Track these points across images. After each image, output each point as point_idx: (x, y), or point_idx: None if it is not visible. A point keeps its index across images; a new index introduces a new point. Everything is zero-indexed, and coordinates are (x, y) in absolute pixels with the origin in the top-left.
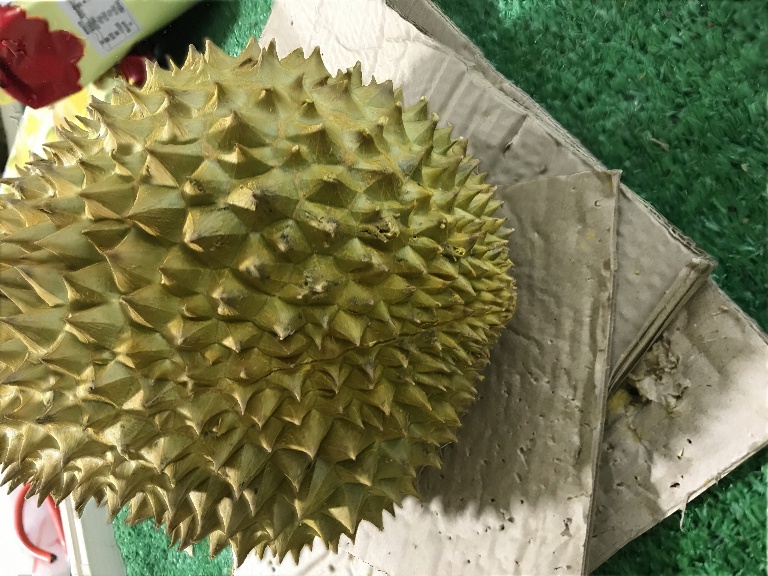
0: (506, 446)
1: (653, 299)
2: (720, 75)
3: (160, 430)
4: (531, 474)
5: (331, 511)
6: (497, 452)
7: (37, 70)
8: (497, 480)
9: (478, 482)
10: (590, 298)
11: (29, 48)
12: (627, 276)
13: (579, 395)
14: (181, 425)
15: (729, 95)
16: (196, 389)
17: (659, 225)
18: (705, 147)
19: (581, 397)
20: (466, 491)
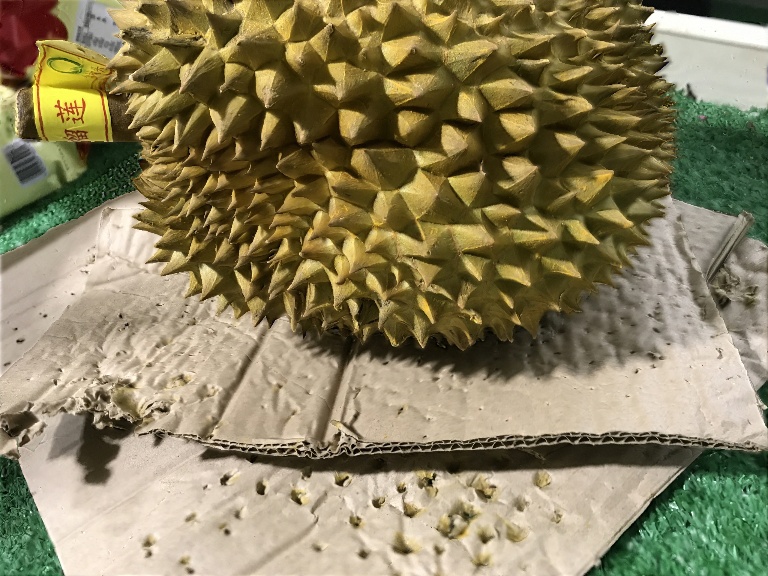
0: (633, 315)
1: (717, 238)
2: (697, 173)
3: (537, 26)
4: (669, 326)
5: (600, 213)
6: (622, 322)
7: (7, 25)
8: (632, 338)
9: (608, 345)
10: (671, 236)
11: (28, 1)
12: (691, 229)
13: (686, 283)
14: (557, 32)
15: (705, 181)
16: (580, 14)
17: (703, 208)
18: (700, 198)
19: (688, 284)
20: (596, 353)
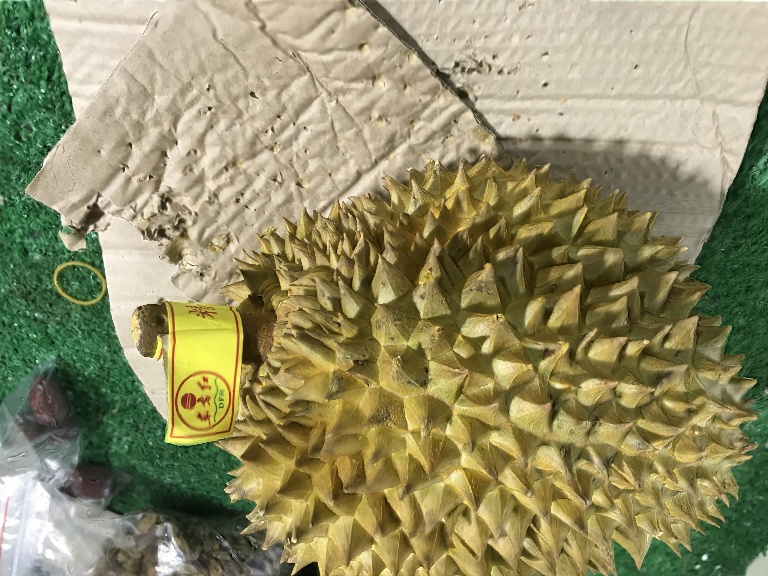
0: None
1: None
2: (742, 336)
3: None
4: None
5: None
6: None
7: None
8: None
9: None
10: None
11: None
12: None
13: None
14: None
15: None
16: None
17: None
18: None
19: None
20: None
